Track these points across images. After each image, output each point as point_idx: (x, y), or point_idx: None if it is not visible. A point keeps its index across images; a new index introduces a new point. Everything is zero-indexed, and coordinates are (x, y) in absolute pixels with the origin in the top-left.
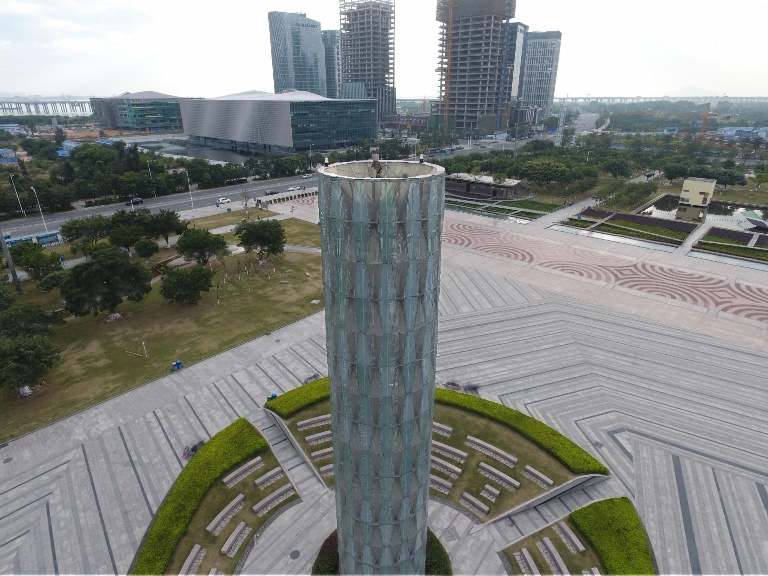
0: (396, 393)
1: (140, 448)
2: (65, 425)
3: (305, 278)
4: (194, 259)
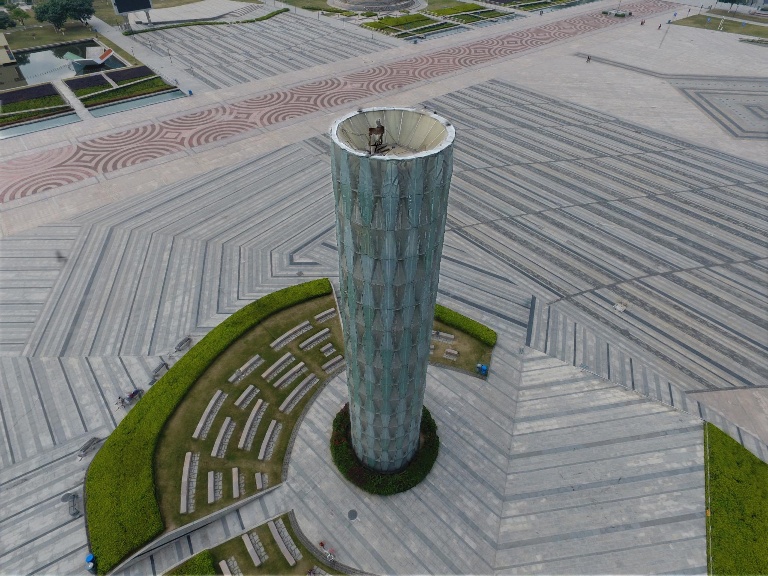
0: None
1: None
2: None
3: None
4: None
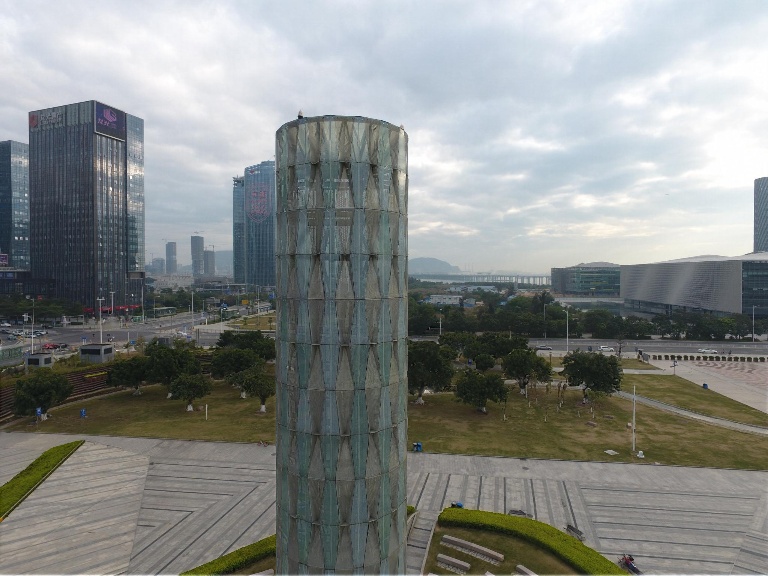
0: (292, 381)
1: None
2: None
3: (623, 428)
4: (515, 379)
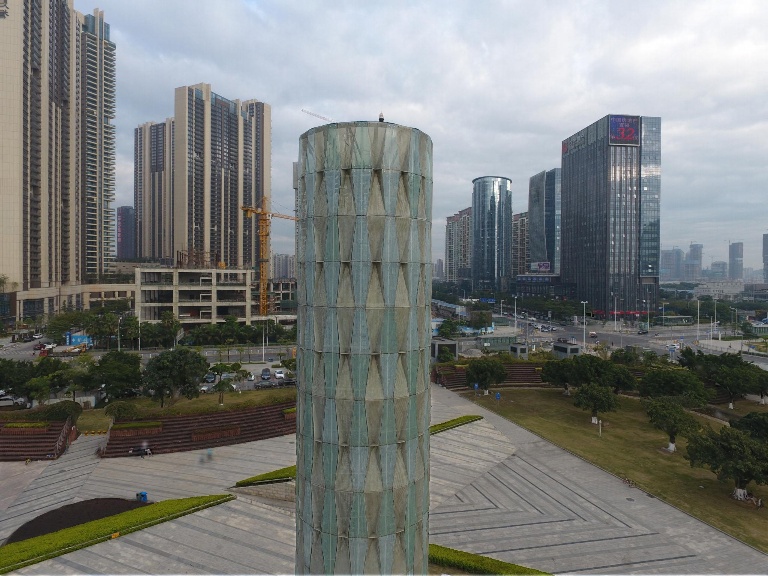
0: None
1: (656, 569)
2: (690, 522)
3: None
4: None
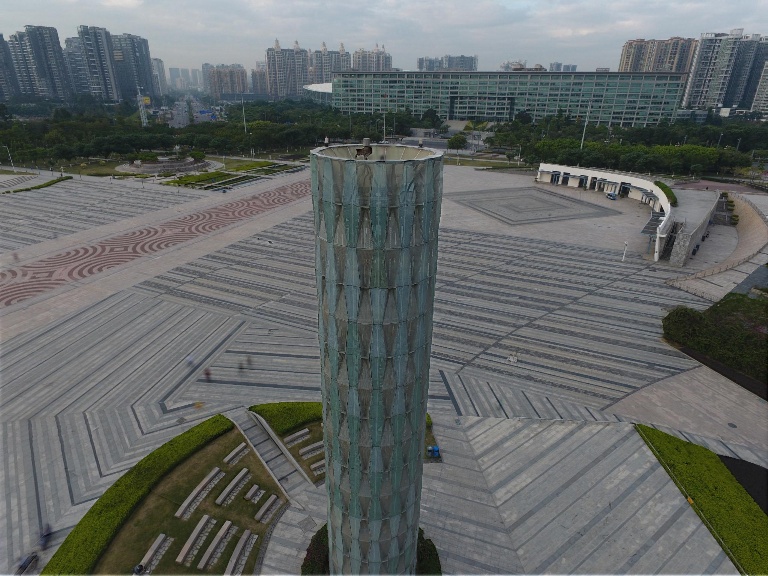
0: None
1: None
2: None
3: None
4: None
